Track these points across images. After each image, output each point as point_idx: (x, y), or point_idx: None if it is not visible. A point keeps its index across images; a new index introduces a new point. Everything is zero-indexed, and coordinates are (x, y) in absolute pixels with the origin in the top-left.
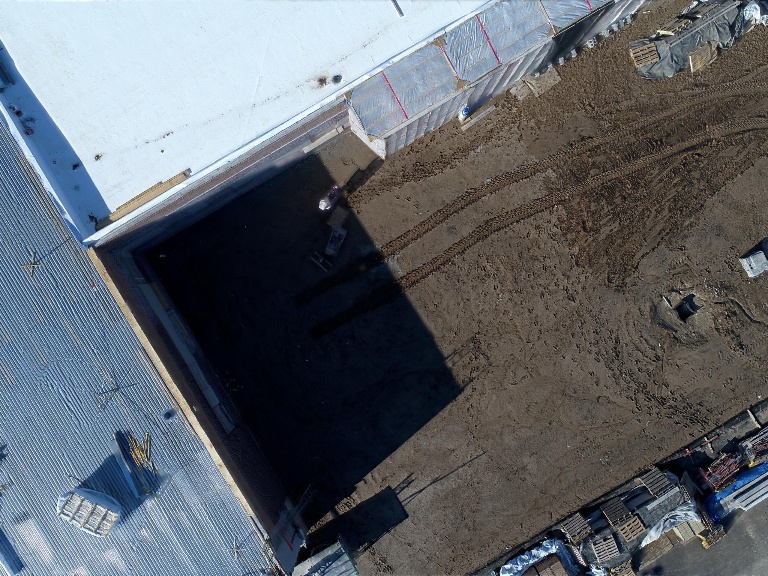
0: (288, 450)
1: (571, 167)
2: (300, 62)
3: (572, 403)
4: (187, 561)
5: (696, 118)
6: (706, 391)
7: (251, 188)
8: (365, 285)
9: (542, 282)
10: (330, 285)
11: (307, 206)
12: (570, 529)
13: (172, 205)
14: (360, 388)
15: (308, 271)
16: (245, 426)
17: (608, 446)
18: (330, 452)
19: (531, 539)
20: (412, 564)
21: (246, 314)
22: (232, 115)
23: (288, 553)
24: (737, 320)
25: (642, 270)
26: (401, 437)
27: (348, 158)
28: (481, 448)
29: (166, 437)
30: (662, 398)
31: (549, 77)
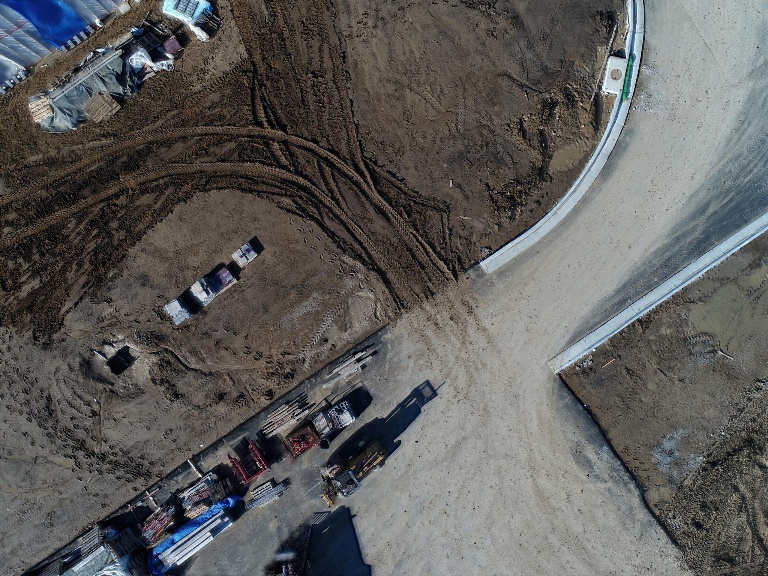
0: None
1: None
2: None
3: (8, 466)
4: None
5: (108, 169)
6: (146, 444)
7: None
8: None
9: None
10: None
11: None
12: None
13: None
14: None
15: None
16: None
17: (50, 507)
18: None
19: None
20: None
21: None
22: None
23: None
24: (171, 369)
25: (68, 326)
26: None
27: None
28: None
29: None
30: (102, 454)
31: None
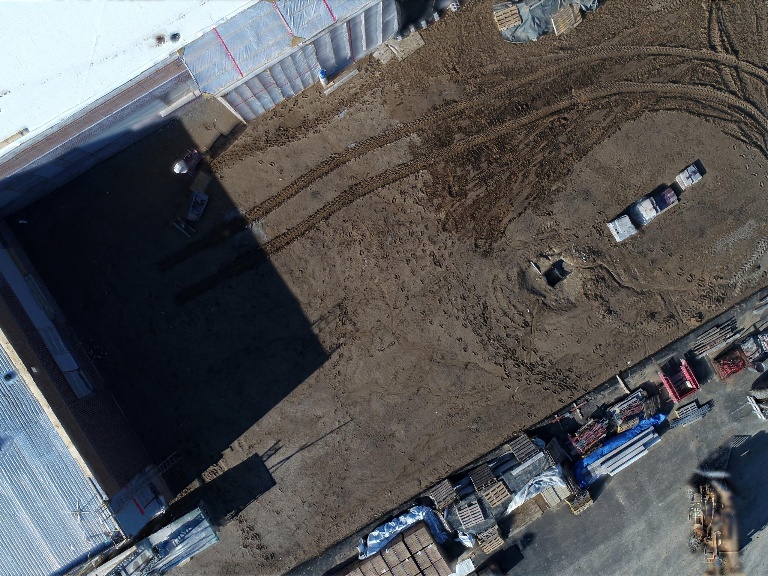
0: (153, 417)
1: (436, 132)
2: (138, 20)
3: (440, 369)
4: (30, 524)
5: (562, 82)
6: (575, 357)
7: (112, 153)
8: (229, 251)
9: (408, 248)
10: (194, 251)
11: (170, 172)
12: (437, 495)
13: (8, 165)
14: (226, 355)
15: (171, 237)
16: (108, 393)
17: (477, 412)
18: (196, 419)
19: (400, 506)
20: (280, 532)
21: (109, 280)
22: (70, 74)
23: (136, 517)
24: (606, 285)
25: (509, 235)
26: (267, 404)
27: (210, 123)
28: (349, 415)
29: (7, 399)
30: (531, 364)
31: (412, 41)
